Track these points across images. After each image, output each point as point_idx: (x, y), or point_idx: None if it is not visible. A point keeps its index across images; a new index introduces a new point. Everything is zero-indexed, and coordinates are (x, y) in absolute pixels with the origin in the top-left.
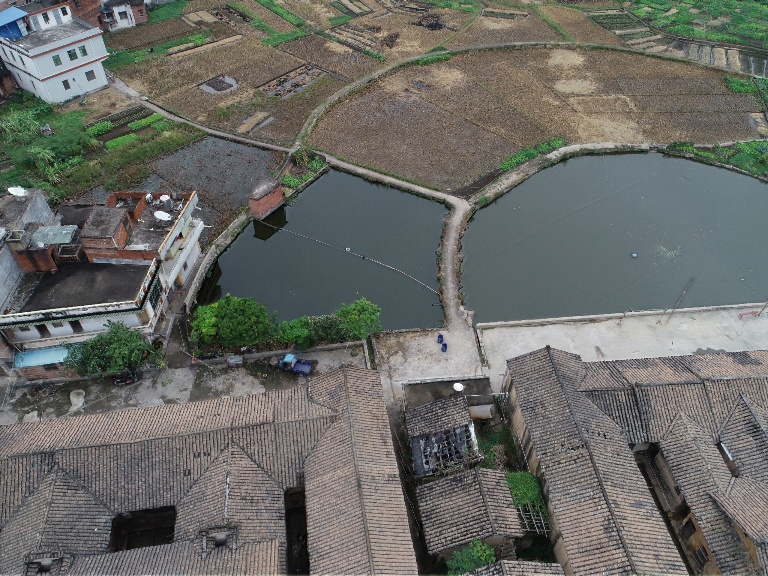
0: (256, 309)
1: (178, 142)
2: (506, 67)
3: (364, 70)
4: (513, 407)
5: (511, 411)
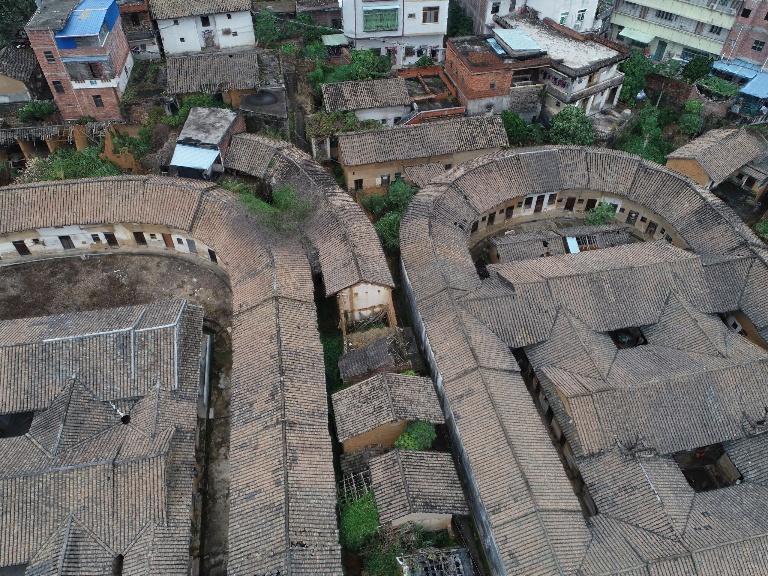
0: None
1: None
2: None
3: None
4: None
5: None
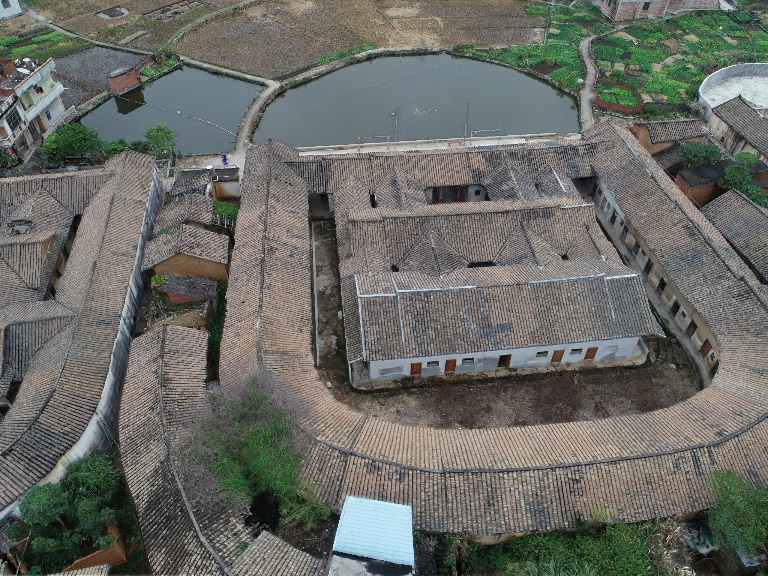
0: (84, 129)
1: (68, 49)
2: None
3: (235, 2)
4: None
5: None
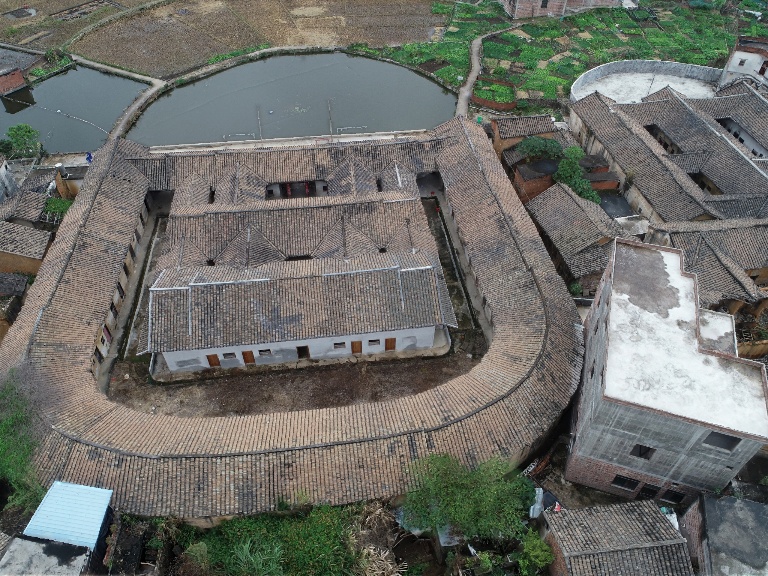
0: None
1: None
2: None
3: None
4: None
5: None
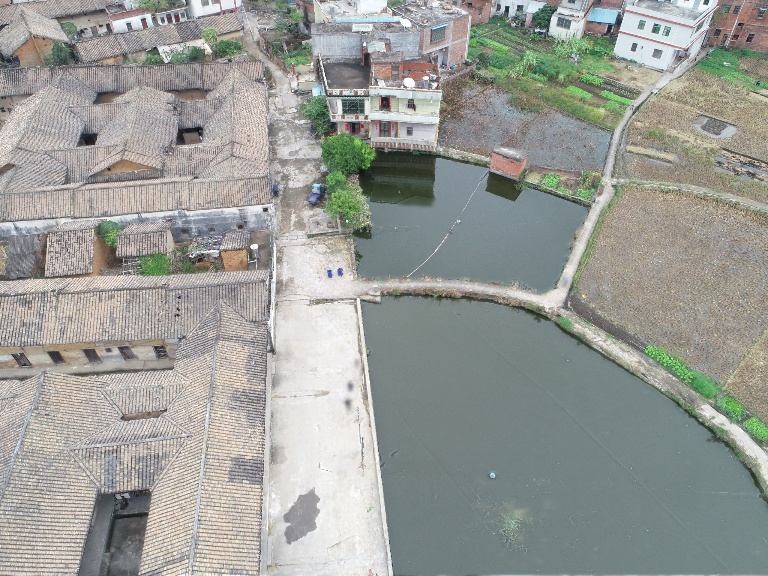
0: (341, 149)
1: (588, 116)
2: None
3: None
4: None
5: None
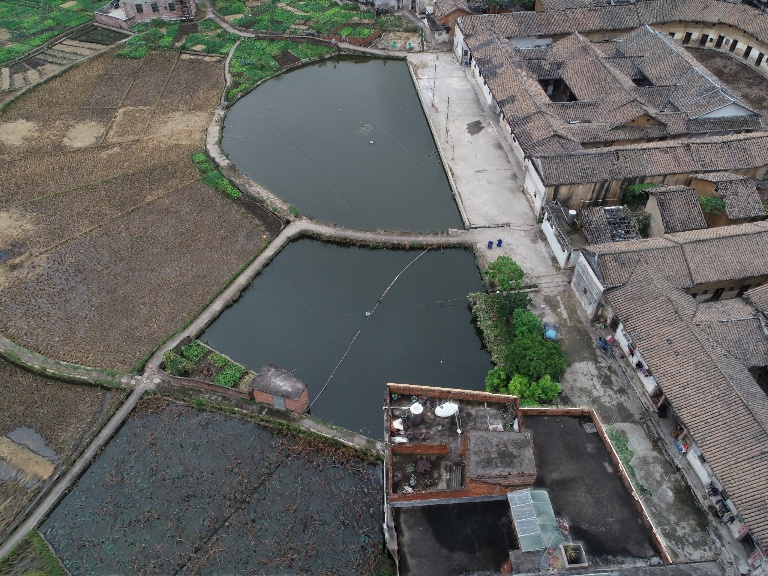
0: None
1: None
2: (5, 174)
3: None
4: (568, 197)
5: (566, 203)
